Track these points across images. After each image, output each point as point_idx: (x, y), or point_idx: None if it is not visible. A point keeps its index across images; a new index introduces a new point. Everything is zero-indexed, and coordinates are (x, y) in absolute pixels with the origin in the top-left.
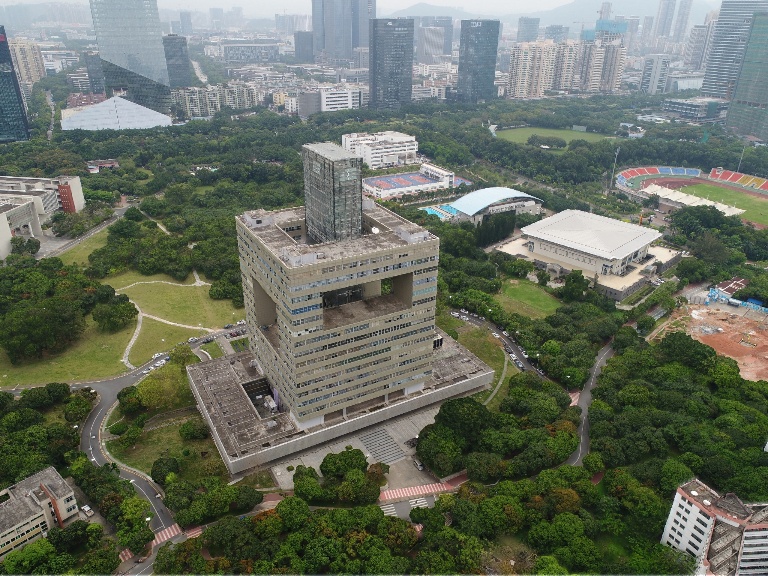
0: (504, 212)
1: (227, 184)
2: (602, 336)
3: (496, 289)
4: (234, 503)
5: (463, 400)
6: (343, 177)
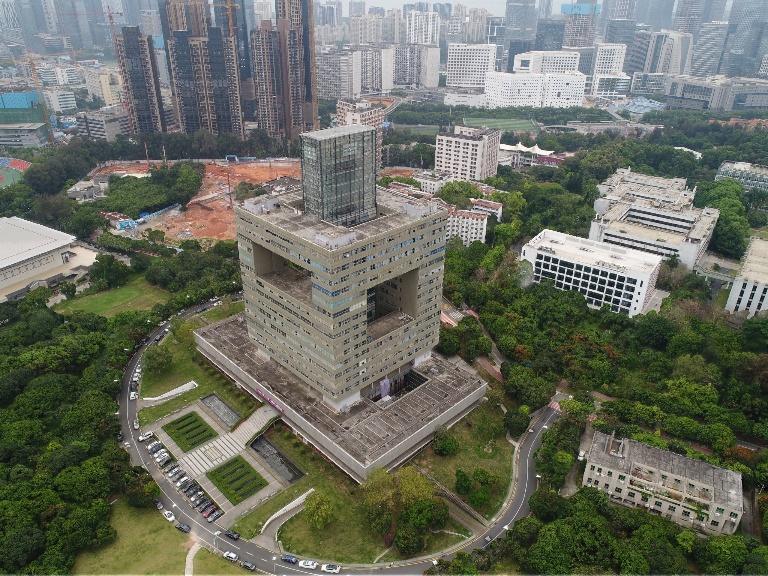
0: None
1: None
2: None
3: None
4: None
5: None
6: None
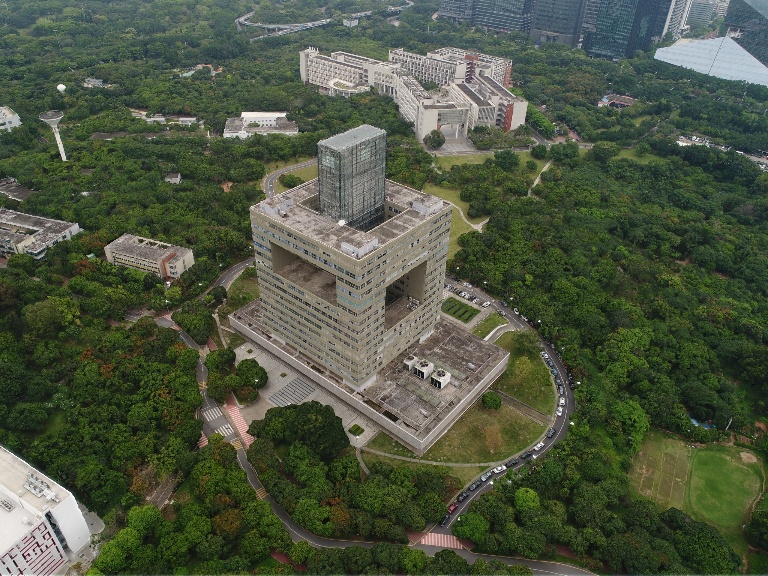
0: None
1: (660, 162)
2: (627, 570)
3: (689, 436)
4: (190, 330)
5: (322, 412)
6: (324, 161)
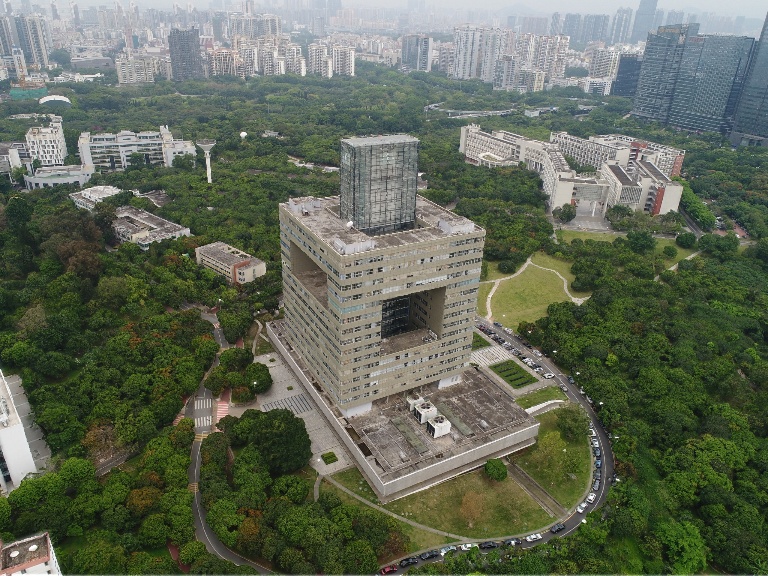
0: None
1: None
2: None
3: None
4: None
5: (287, 420)
6: (344, 159)
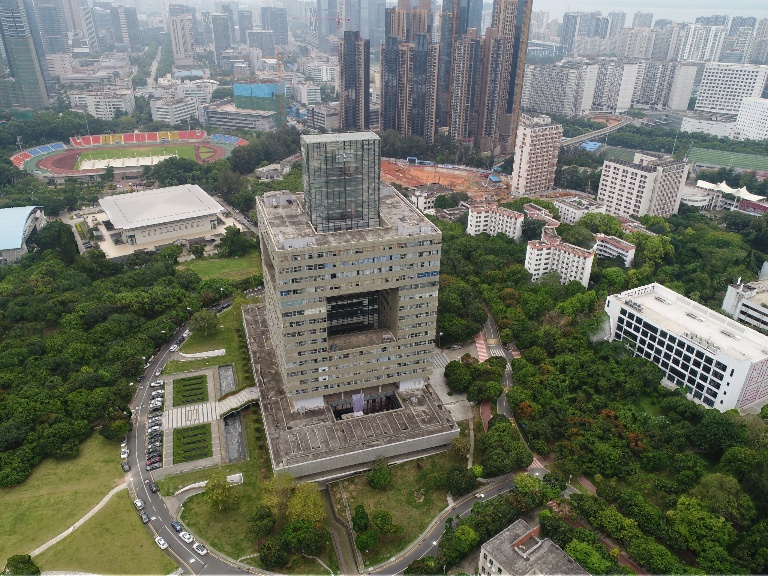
0: (32, 232)
1: None
2: None
3: None
4: None
5: None
6: None
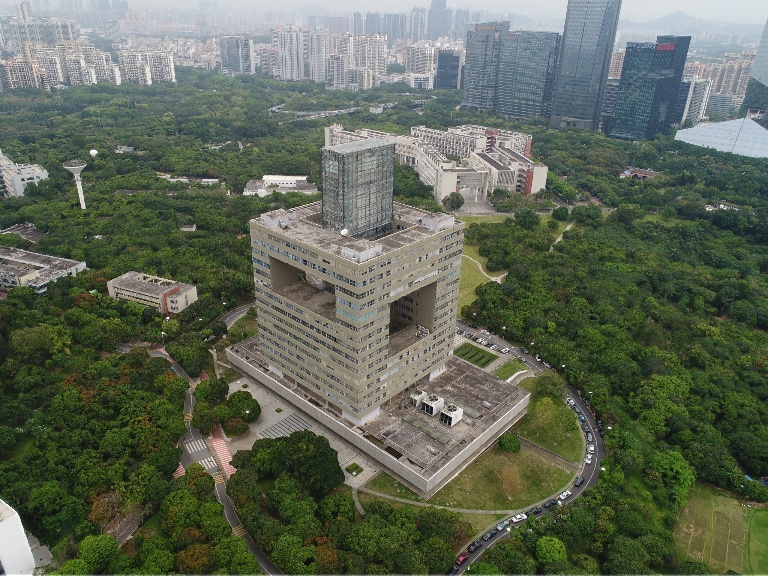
0: None
1: (688, 224)
2: None
3: (743, 493)
4: None
5: (314, 441)
6: (328, 167)
